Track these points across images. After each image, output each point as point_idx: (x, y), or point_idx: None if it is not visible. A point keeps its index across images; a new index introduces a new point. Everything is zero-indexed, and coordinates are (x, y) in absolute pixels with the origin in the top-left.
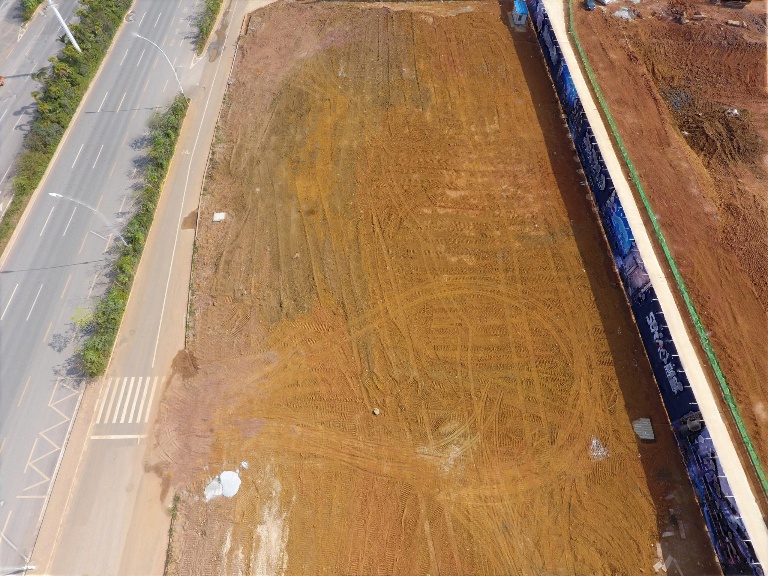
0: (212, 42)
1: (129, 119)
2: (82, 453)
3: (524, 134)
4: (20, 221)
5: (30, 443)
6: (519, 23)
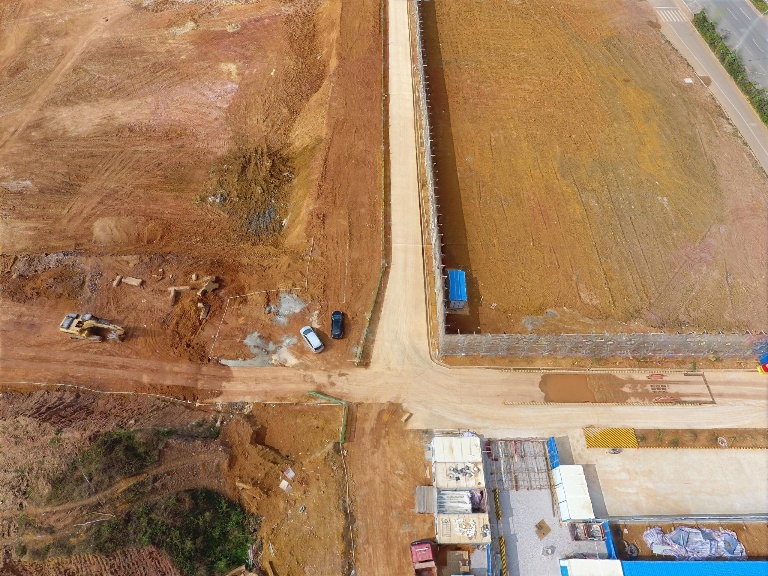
0: None
1: None
2: (676, 3)
3: (469, 126)
4: None
5: None
6: None
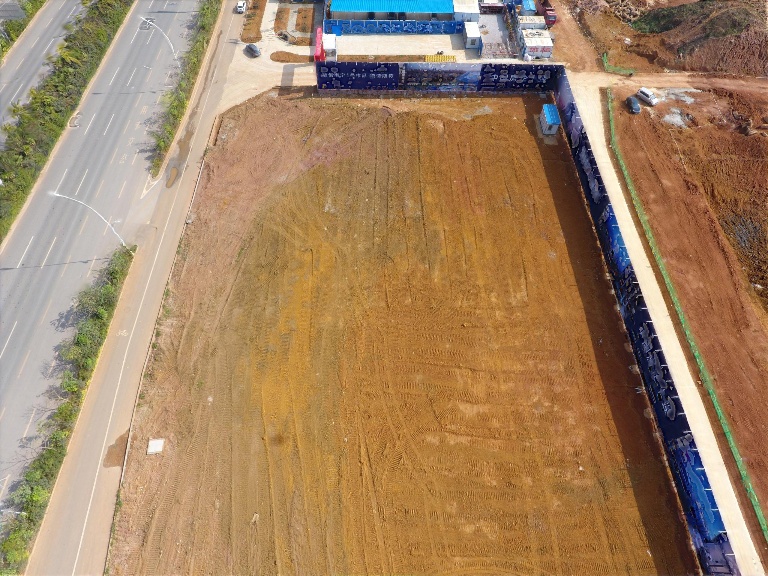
0: (172, 157)
1: (55, 279)
2: None
3: (560, 309)
4: None
5: None
6: (549, 133)
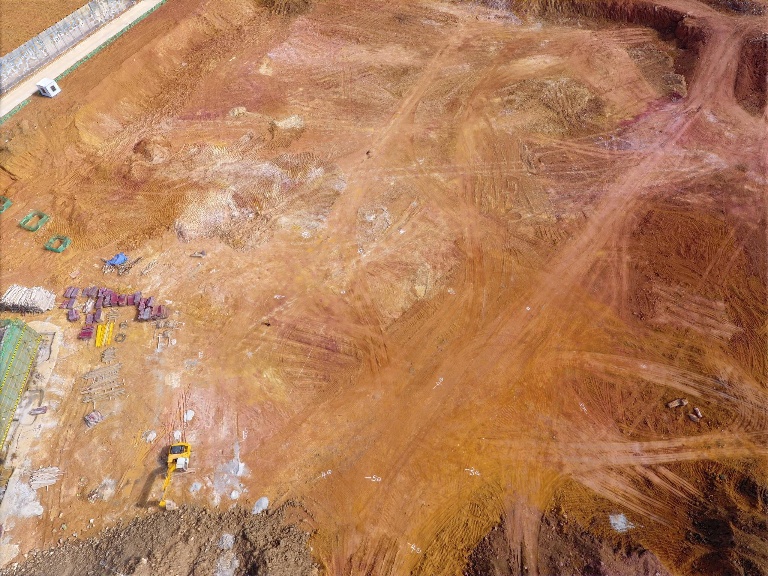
0: None
1: None
2: None
3: None
4: None
5: None
6: None
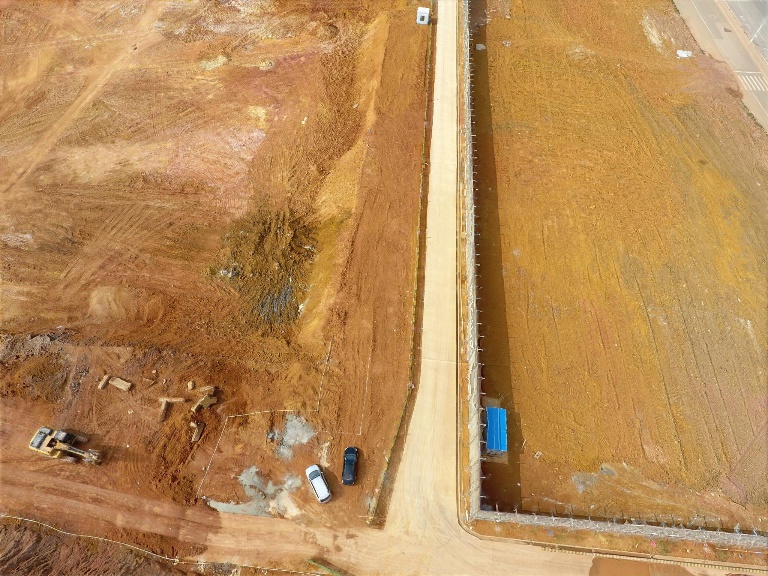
0: None
1: None
2: (761, 68)
3: (518, 210)
4: None
5: None
6: None
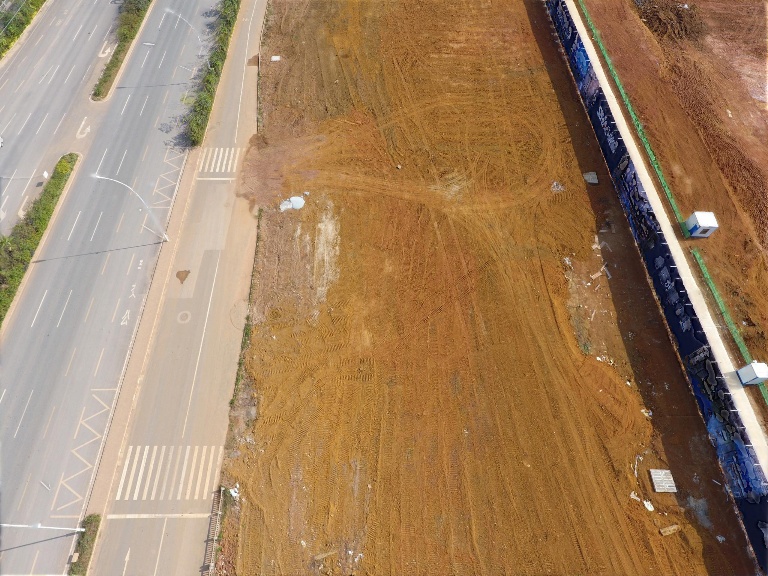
0: None
1: None
2: (192, 186)
3: (511, 9)
4: (125, 59)
5: (154, 180)
6: None
